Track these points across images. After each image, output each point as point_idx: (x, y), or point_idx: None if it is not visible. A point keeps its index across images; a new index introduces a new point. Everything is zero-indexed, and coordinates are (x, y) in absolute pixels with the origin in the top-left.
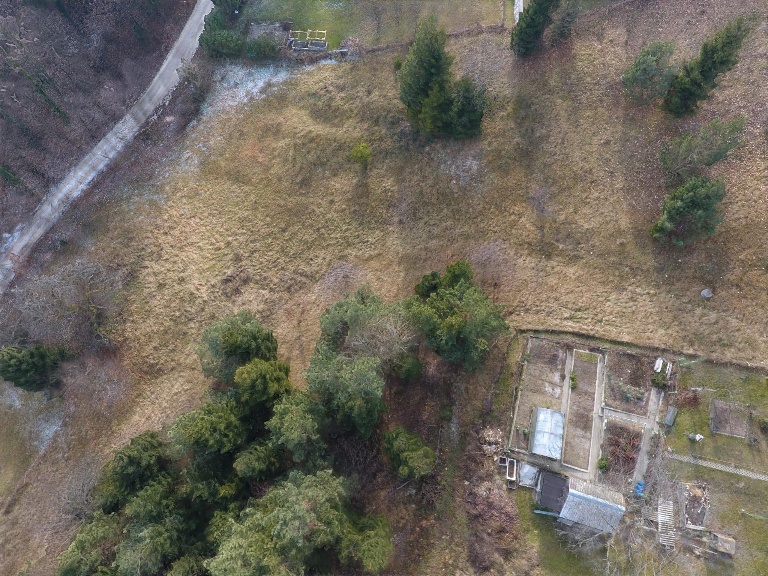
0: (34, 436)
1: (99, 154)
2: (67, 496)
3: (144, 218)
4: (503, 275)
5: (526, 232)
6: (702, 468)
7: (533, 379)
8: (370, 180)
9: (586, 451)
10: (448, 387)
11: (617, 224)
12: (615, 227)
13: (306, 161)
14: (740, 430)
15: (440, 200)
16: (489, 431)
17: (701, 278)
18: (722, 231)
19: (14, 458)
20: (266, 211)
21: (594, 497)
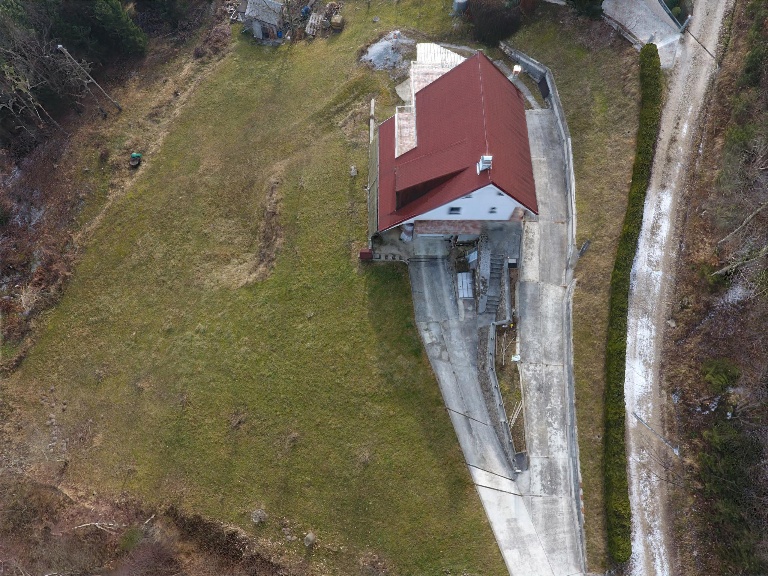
0: None
1: None
2: None
3: None
4: None
5: None
6: None
7: None
8: None
9: (282, 1)
10: None
11: None
12: None
13: None
14: None
15: None
16: None
17: None
18: None
19: None
20: None
21: None
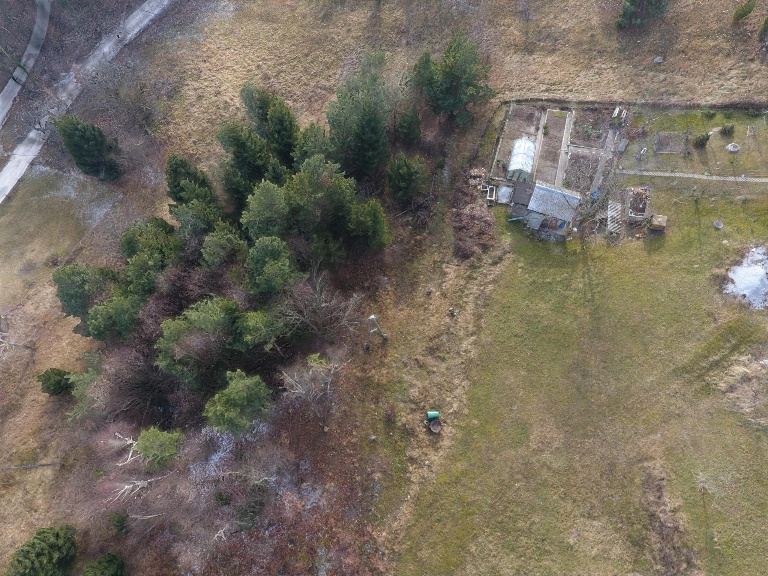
0: (87, 217)
1: (146, 11)
2: (121, 233)
3: (186, 51)
4: (492, 69)
5: (513, 37)
6: (645, 177)
7: (513, 131)
8: (383, 13)
9: (553, 176)
10: (442, 147)
11: (589, 22)
12: (587, 24)
13: (328, 0)
14: (677, 148)
15: (442, 23)
16: (475, 170)
17: (655, 51)
18: (674, 15)
19: (70, 231)
20: (292, 41)
21: (556, 190)
